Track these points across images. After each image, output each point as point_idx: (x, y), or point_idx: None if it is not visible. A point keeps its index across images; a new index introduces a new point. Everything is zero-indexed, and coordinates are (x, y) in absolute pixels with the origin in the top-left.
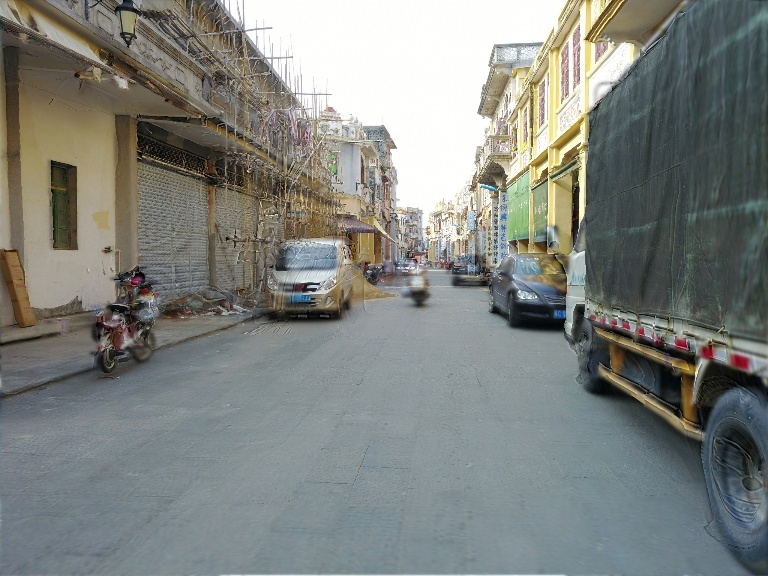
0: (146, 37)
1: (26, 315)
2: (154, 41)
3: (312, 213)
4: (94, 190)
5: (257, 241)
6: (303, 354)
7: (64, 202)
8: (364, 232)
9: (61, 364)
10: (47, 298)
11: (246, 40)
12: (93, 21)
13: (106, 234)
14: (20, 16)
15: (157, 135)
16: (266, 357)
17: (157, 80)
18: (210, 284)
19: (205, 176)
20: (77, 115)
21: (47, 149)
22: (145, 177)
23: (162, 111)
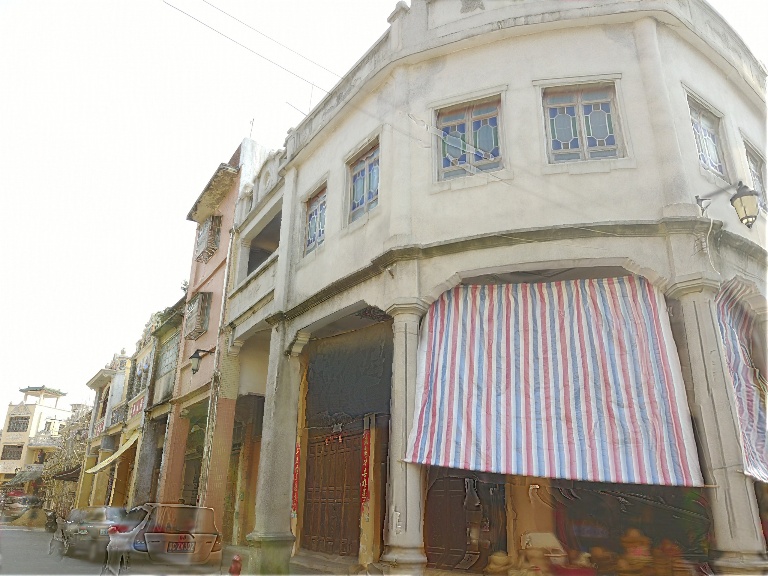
0: None
1: None
2: None
3: None
4: None
5: None
6: None
7: None
8: (63, 480)
9: None
10: None
11: None
12: None
13: None
14: None
15: None
16: None
17: None
18: None
19: None
20: None
21: None
22: None
23: None
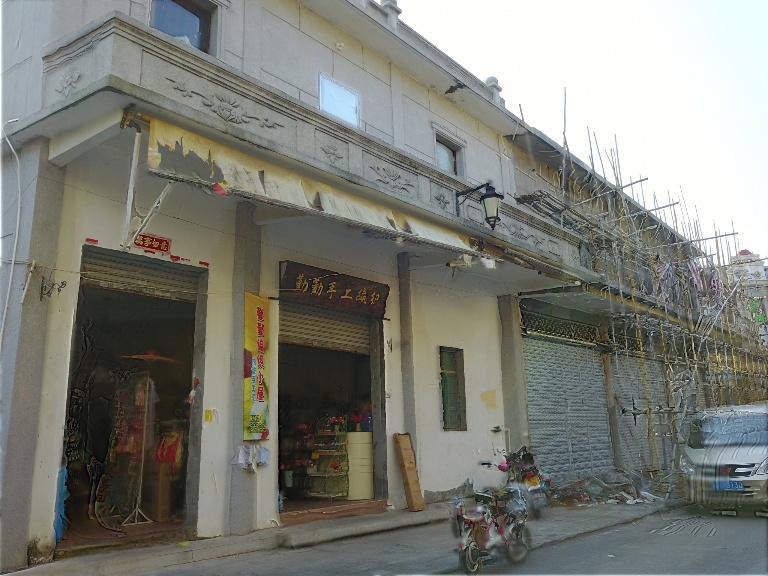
0: (516, 219)
1: (416, 499)
2: (524, 221)
3: (736, 374)
4: (481, 370)
5: (661, 412)
6: (731, 573)
7: (454, 384)
8: None
9: (432, 559)
10: (439, 481)
11: (627, 201)
12: (464, 215)
13: (494, 413)
14: (396, 224)
15: (541, 309)
16: (674, 572)
17: (528, 255)
18: (615, 464)
19: (597, 344)
20: (461, 302)
21: (436, 336)
22: (532, 352)
23: (540, 285)
